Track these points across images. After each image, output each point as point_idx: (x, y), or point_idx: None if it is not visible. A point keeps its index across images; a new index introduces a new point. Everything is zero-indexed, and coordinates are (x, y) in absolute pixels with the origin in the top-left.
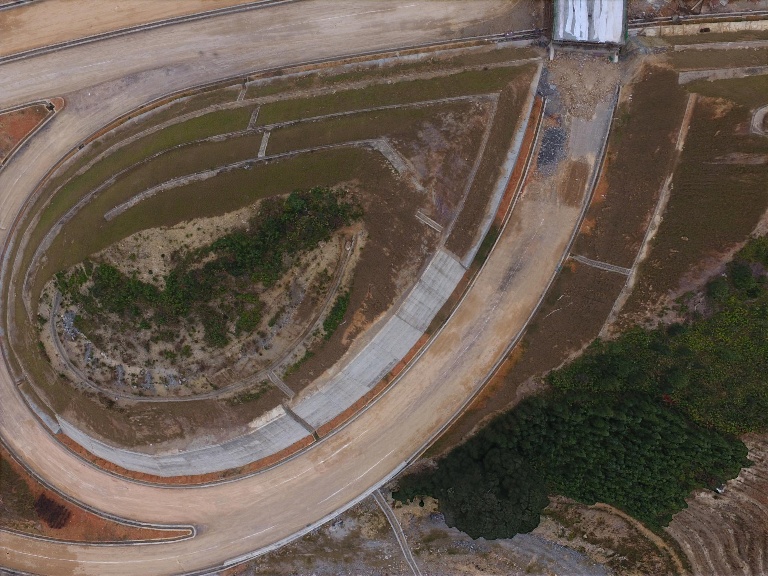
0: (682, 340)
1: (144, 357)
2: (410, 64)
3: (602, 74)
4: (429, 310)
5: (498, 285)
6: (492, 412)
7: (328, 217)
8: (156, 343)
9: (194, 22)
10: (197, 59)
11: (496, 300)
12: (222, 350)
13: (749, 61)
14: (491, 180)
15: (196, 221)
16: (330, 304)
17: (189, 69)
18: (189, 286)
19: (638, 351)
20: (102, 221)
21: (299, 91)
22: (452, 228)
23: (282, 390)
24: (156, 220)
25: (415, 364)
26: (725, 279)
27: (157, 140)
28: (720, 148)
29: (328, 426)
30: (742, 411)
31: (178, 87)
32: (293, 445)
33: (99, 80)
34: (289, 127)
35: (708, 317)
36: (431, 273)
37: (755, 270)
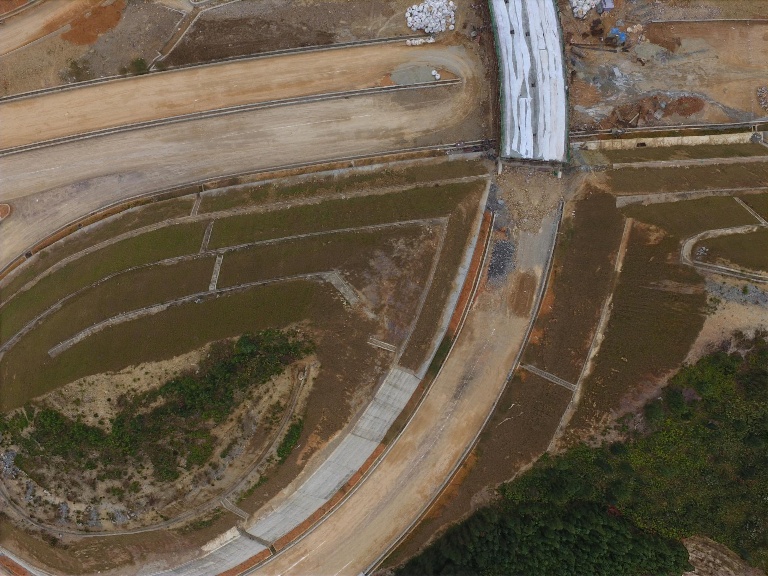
0: (624, 457)
1: (90, 494)
2: (364, 175)
3: (547, 191)
4: (385, 422)
5: (452, 394)
6: (448, 522)
7: (279, 357)
8: (103, 481)
9: (148, 129)
10: (151, 166)
11: (450, 408)
12: (173, 482)
13: (679, 185)
14: (443, 295)
15: (144, 365)
16: (284, 431)
17: (142, 175)
18: (136, 431)
19: (584, 466)
20: (46, 357)
21: (254, 206)
22: (405, 347)
23: (236, 514)
24: (102, 364)
25: (372, 474)
26: (661, 402)
27: (107, 259)
28: (654, 274)
29: (285, 539)
30: (682, 519)
31: (131, 193)
32: (249, 560)
33: (48, 186)
34: (242, 250)
35: (647, 436)
36: (385, 390)
37: (688, 395)
